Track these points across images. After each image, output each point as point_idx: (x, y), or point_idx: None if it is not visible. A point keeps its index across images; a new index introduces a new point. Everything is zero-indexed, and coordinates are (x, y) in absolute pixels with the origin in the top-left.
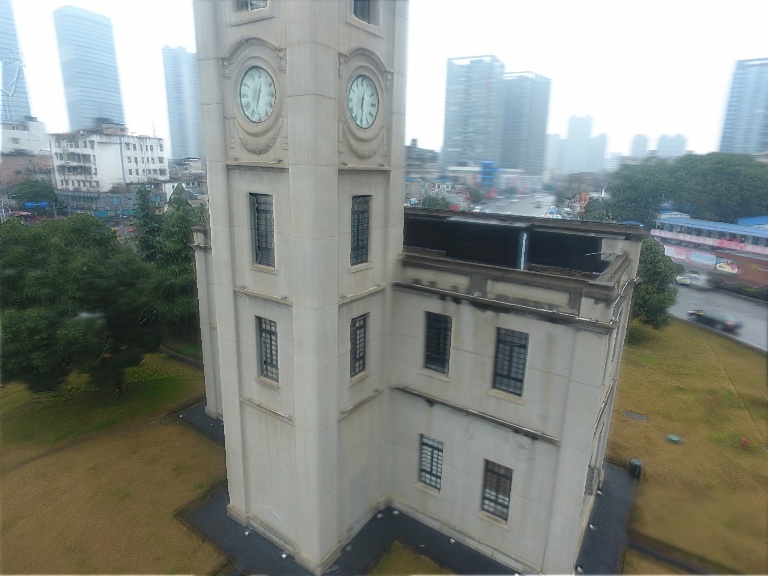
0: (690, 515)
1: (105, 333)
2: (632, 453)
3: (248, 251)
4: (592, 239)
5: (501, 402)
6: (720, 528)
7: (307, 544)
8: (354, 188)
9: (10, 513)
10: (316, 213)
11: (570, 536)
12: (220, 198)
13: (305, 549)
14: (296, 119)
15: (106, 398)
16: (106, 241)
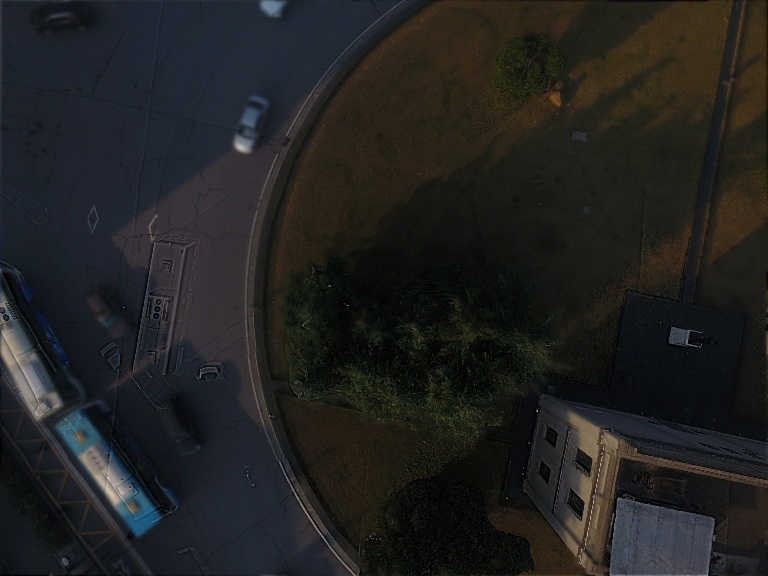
0: None
1: None
2: None
3: None
4: None
5: None
6: None
7: None
8: None
9: None
10: None
11: None
12: None
13: None
14: None
15: None
16: None
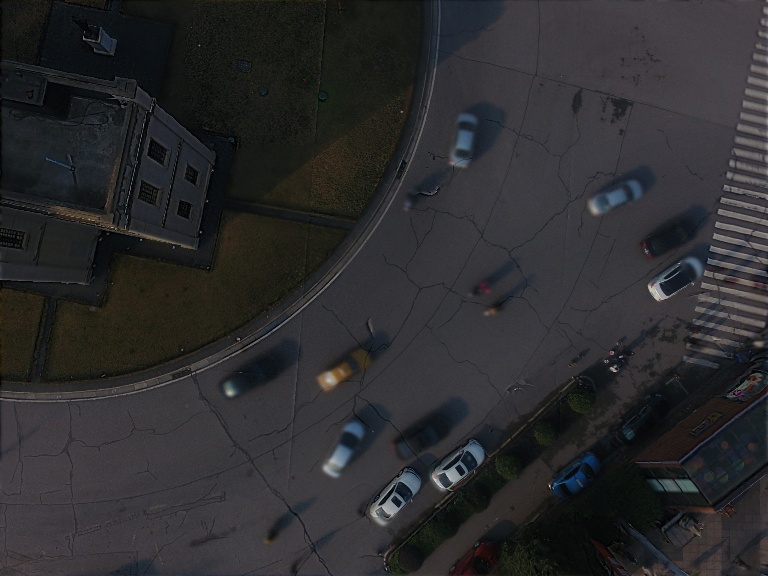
0: (257, 172)
1: None
2: (234, 122)
3: None
4: None
5: None
6: (269, 177)
7: None
8: None
9: None
10: None
11: None
12: None
13: None
14: None
15: None
16: None
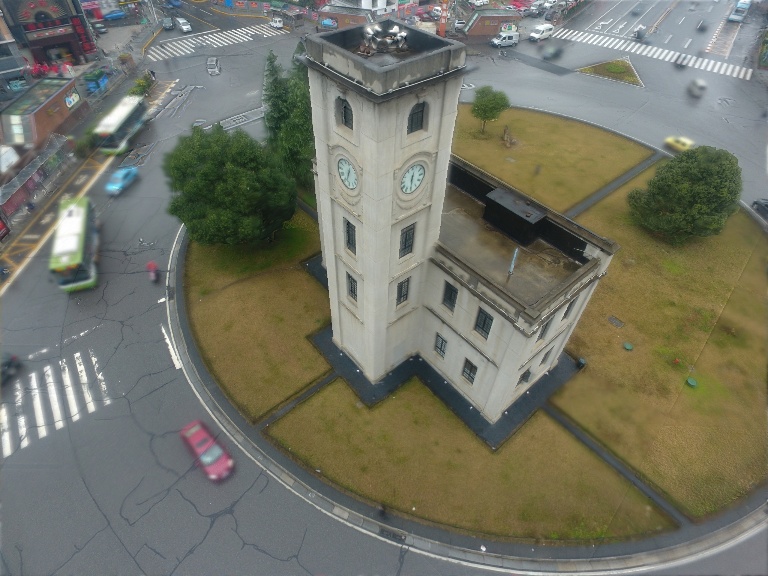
0: (593, 400)
1: (262, 221)
2: (588, 352)
3: (342, 242)
4: (581, 241)
5: (476, 339)
6: (604, 412)
7: (369, 371)
8: (403, 225)
9: (229, 317)
10: (376, 252)
11: (497, 404)
12: (327, 210)
13: (368, 372)
14: (367, 205)
15: (263, 243)
16: (257, 158)
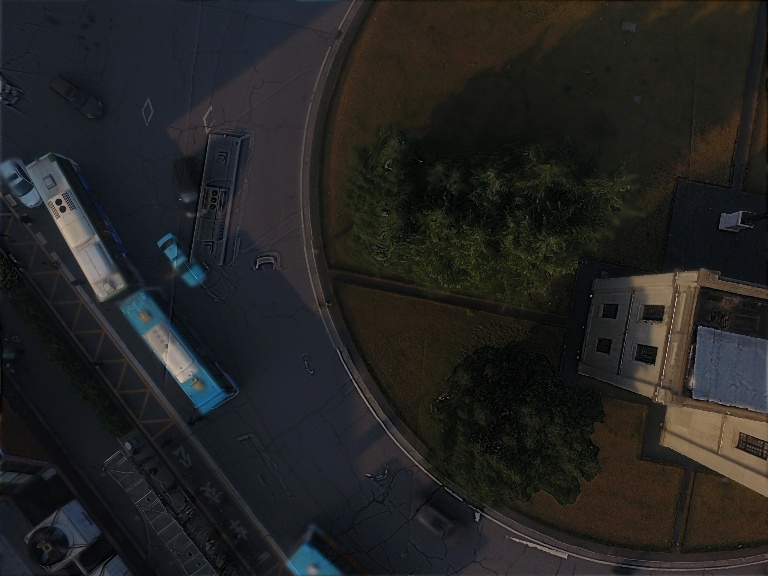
0: None
1: None
2: None
3: None
4: None
5: None
6: None
7: None
8: None
9: None
10: None
11: None
12: None
13: None
14: None
15: None
16: None
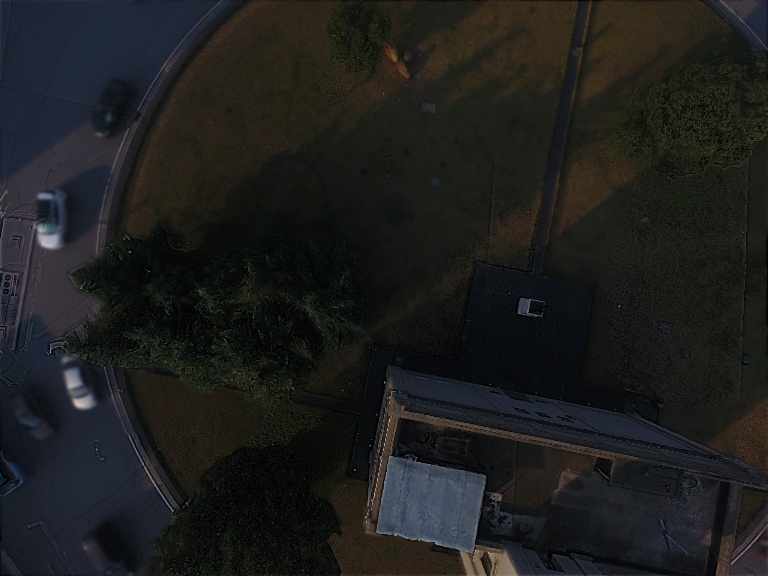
0: None
1: None
2: (658, 384)
3: None
4: None
5: None
6: (694, 440)
7: None
8: None
9: None
10: None
11: None
12: None
13: None
14: None
15: None
16: None
